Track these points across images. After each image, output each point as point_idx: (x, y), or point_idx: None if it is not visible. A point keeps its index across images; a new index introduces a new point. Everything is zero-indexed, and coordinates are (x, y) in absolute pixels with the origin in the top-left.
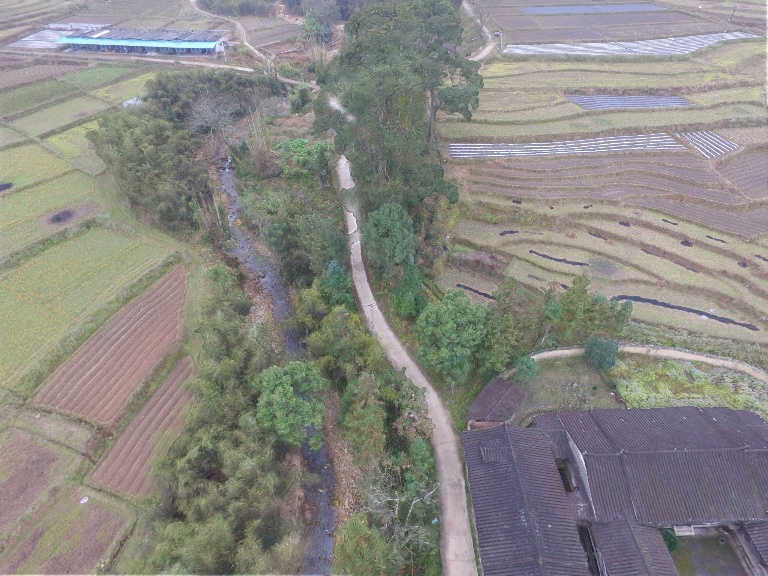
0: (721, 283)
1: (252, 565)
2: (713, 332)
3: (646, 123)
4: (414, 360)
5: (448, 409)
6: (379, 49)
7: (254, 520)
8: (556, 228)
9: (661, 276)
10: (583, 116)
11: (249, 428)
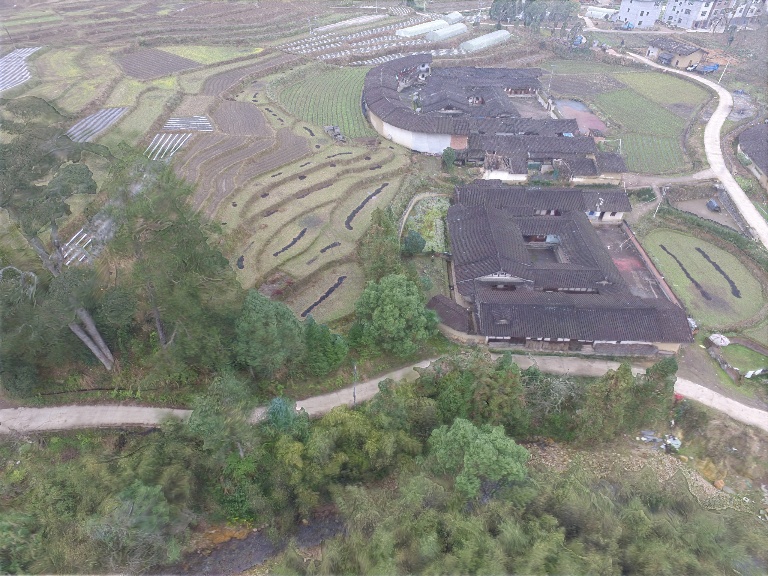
0: (346, 180)
1: (649, 478)
2: (388, 198)
3: (135, 135)
4: (383, 374)
5: (440, 355)
6: (7, 164)
7: (606, 489)
8: (250, 232)
9: (333, 199)
10: (85, 159)
11: (536, 485)
